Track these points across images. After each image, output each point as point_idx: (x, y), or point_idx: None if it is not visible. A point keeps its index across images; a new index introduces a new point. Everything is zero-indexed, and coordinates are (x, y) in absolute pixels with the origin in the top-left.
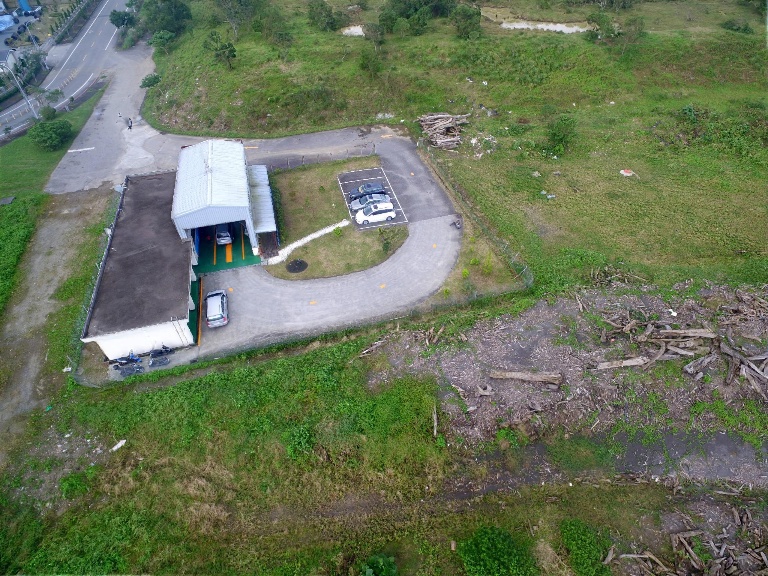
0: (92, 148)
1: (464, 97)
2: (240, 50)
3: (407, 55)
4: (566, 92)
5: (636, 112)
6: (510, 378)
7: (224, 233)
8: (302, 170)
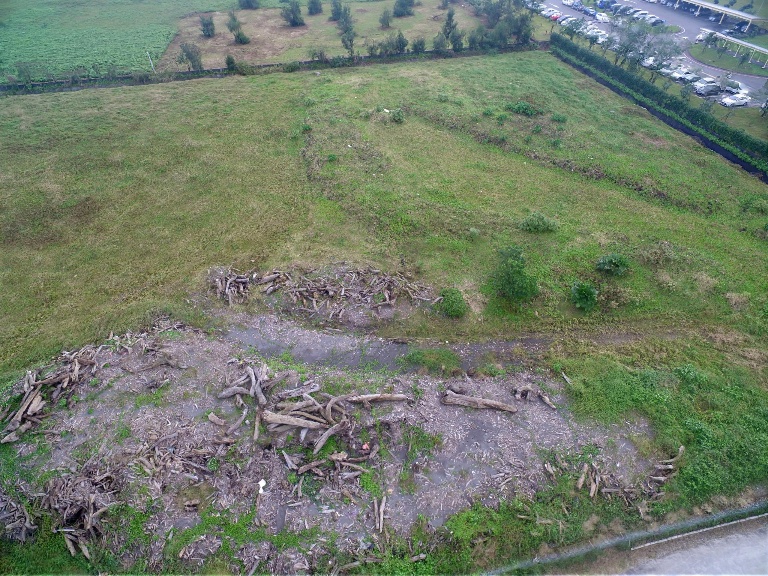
0: None
1: None
2: None
3: None
4: None
5: None
6: None
7: None
8: None
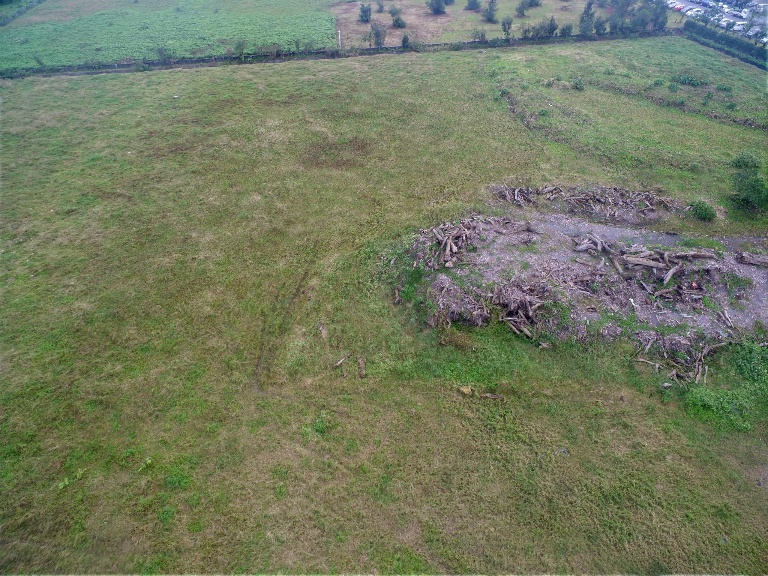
0: None
1: None
2: None
3: None
4: None
5: None
6: None
7: None
8: None
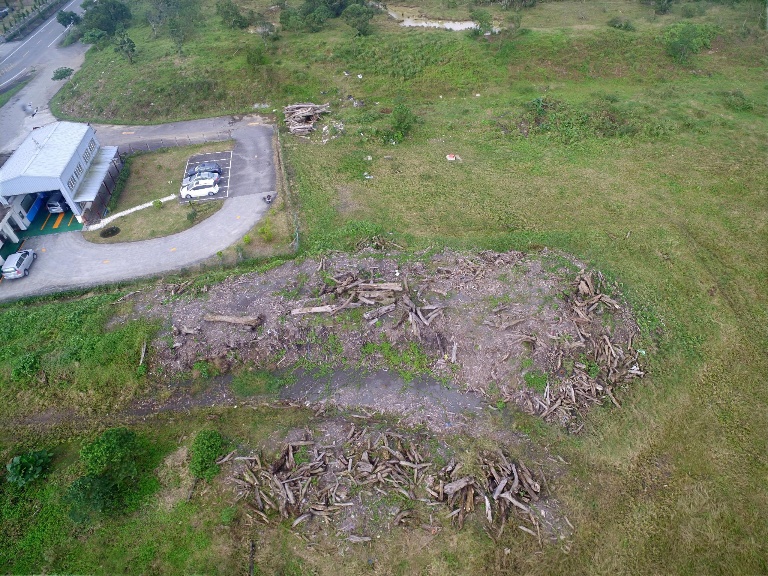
0: None
1: (334, 89)
2: (152, 46)
3: (295, 50)
4: (435, 85)
5: (491, 103)
6: (219, 321)
7: (54, 203)
8: (161, 152)
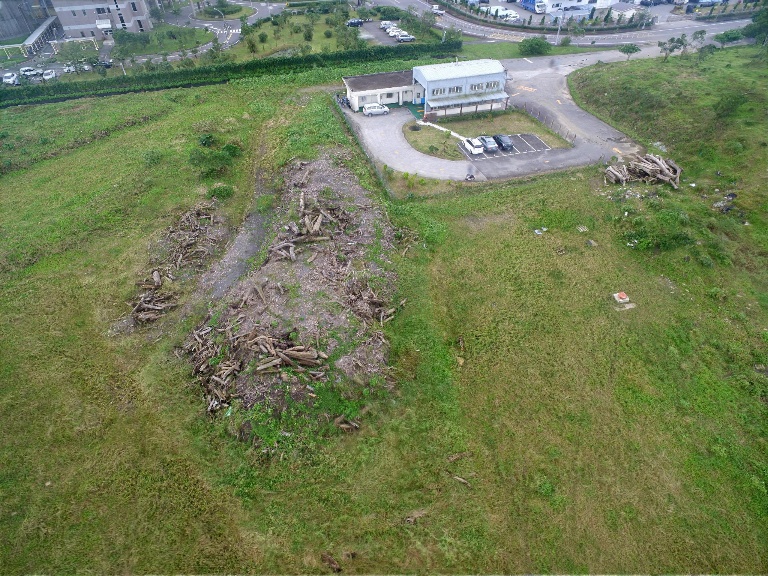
0: (531, 62)
1: (732, 177)
2: None
3: None
4: None
5: None
6: None
7: None
8: (532, 121)
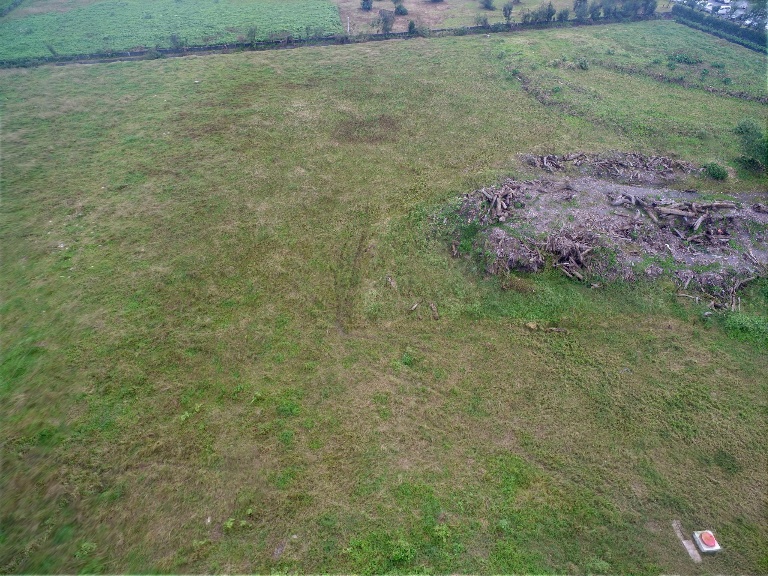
0: None
1: None
2: None
3: None
4: None
5: None
6: None
7: None
8: None
